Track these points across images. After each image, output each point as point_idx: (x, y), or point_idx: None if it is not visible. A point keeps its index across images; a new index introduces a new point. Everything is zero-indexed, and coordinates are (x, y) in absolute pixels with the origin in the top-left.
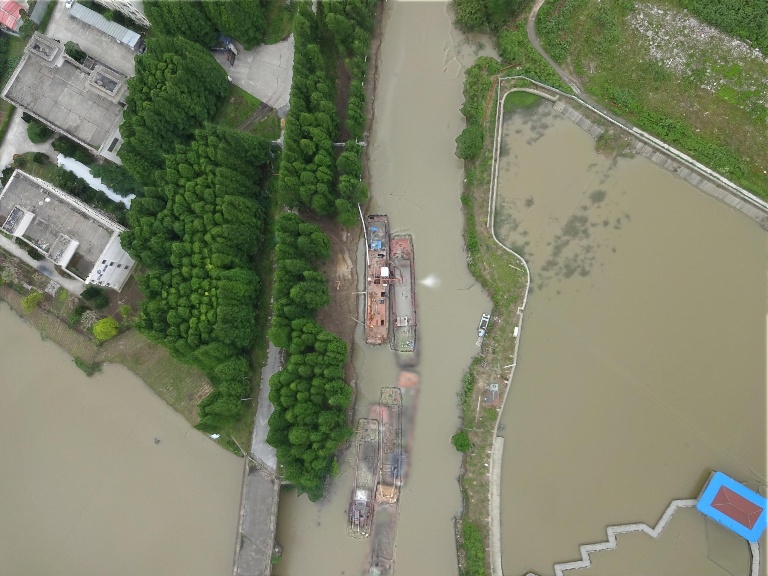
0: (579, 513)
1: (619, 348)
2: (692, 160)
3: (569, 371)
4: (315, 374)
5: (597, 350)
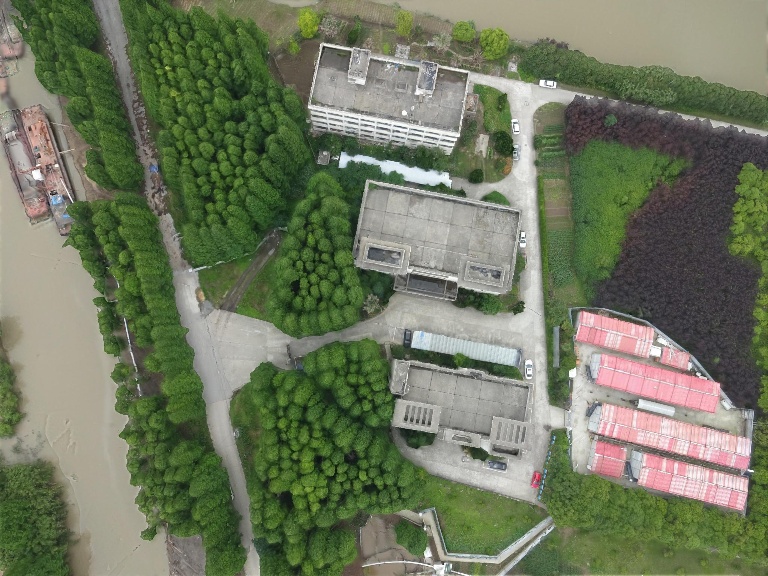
0: None
1: None
2: None
3: None
4: (45, 40)
5: None
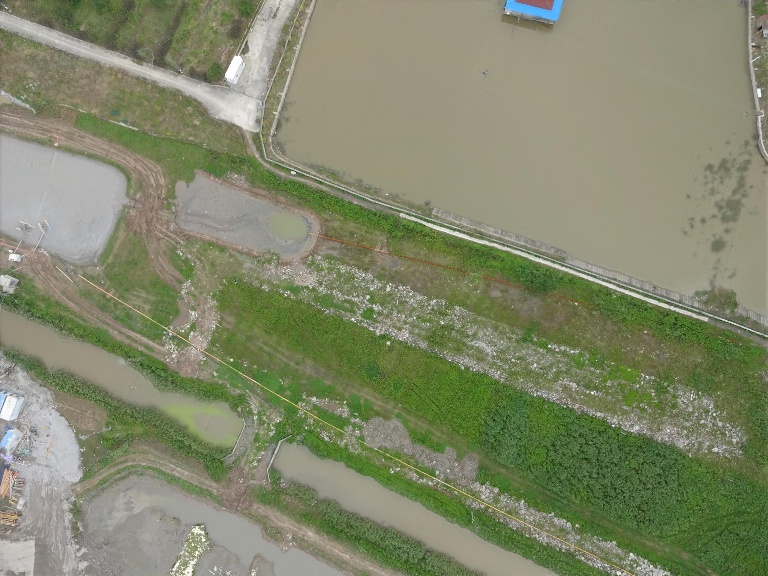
0: None
1: (669, 99)
2: (645, 299)
3: (704, 68)
4: None
5: (690, 91)
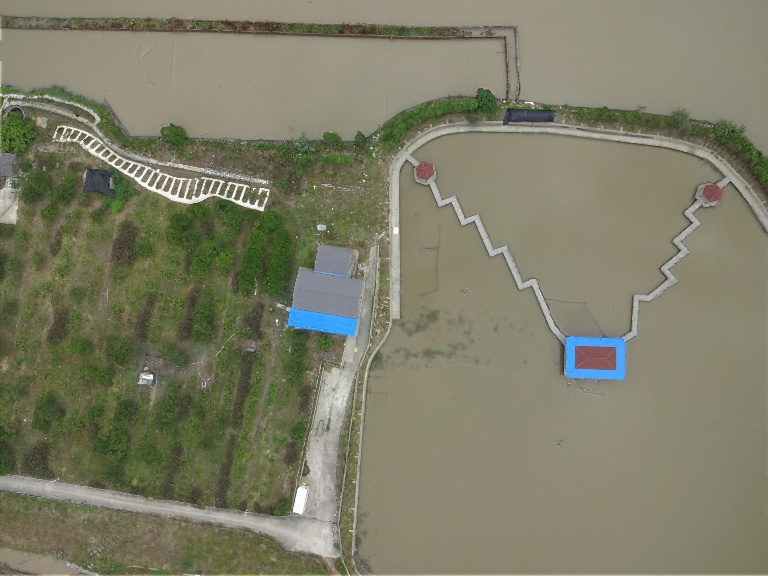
0: (704, 278)
1: (765, 444)
2: None
3: None
4: None
5: None
